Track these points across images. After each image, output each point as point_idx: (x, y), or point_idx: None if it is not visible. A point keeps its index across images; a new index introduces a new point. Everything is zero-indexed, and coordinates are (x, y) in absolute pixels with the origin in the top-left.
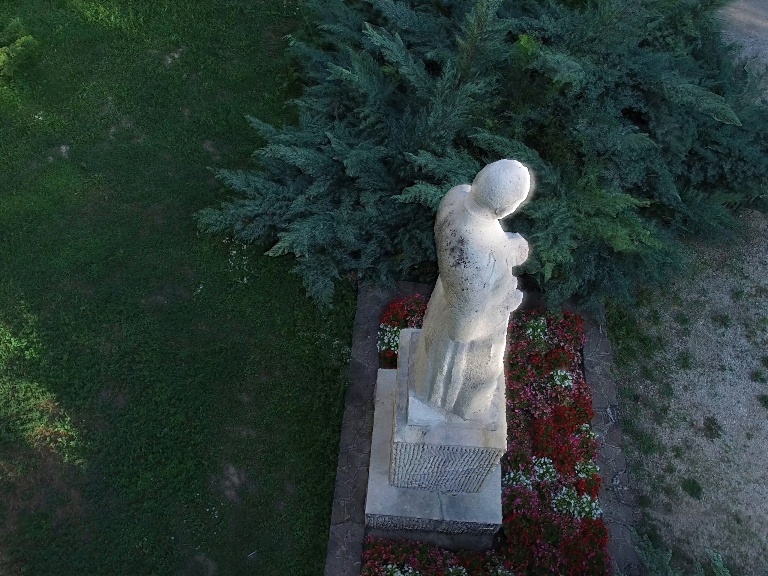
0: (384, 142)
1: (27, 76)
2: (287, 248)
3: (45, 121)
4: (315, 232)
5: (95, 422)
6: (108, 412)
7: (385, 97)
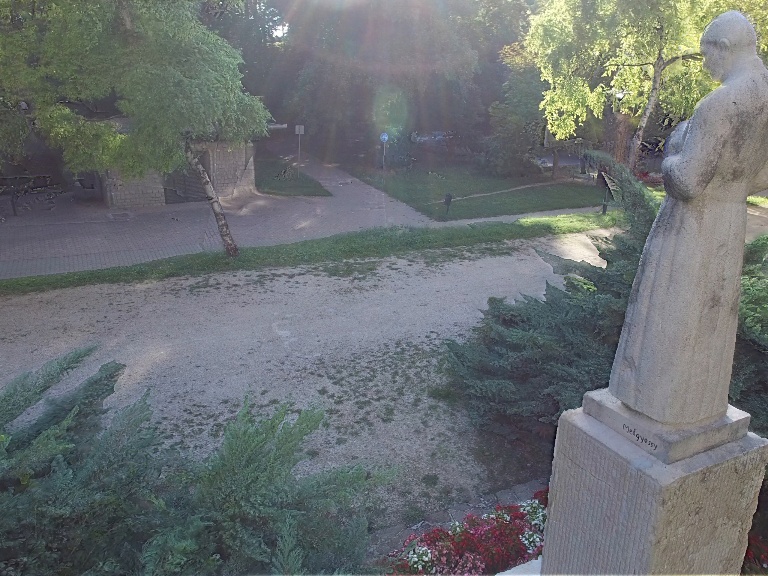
0: None
1: None
2: None
3: None
4: None
5: None
6: None
7: None
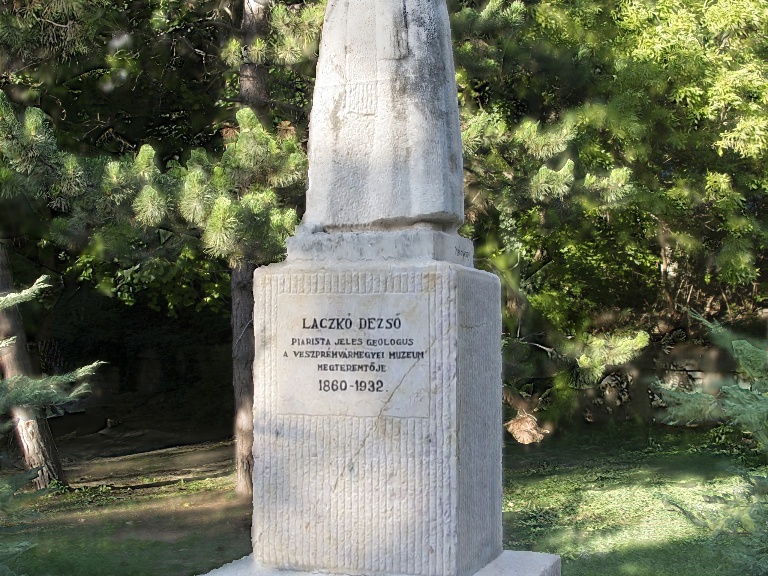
0: None
1: None
2: None
3: None
4: None
5: None
6: None
7: None
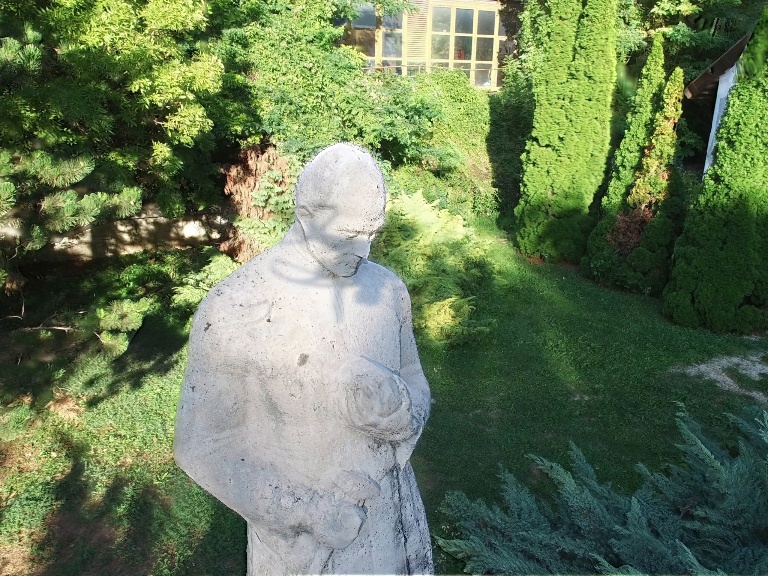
0: (710, 565)
1: (465, 353)
2: (464, 554)
3: (442, 380)
4: (519, 575)
5: (197, 574)
6: (210, 575)
7: (759, 525)
